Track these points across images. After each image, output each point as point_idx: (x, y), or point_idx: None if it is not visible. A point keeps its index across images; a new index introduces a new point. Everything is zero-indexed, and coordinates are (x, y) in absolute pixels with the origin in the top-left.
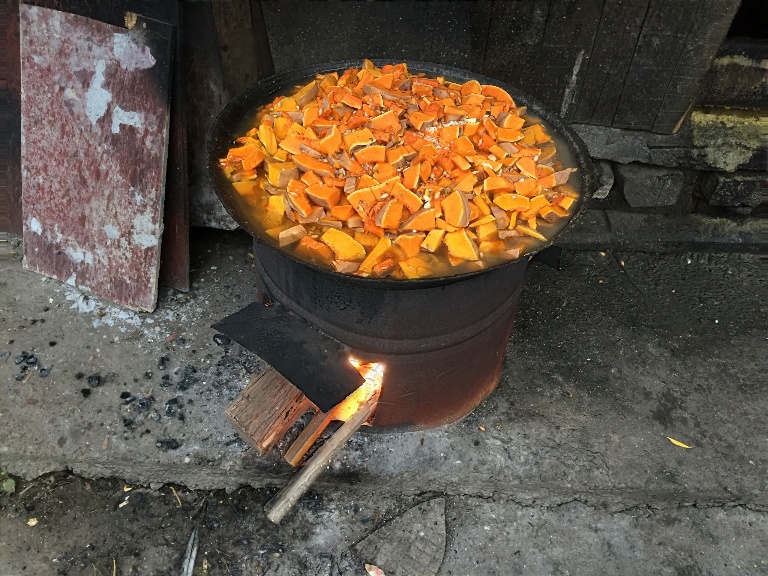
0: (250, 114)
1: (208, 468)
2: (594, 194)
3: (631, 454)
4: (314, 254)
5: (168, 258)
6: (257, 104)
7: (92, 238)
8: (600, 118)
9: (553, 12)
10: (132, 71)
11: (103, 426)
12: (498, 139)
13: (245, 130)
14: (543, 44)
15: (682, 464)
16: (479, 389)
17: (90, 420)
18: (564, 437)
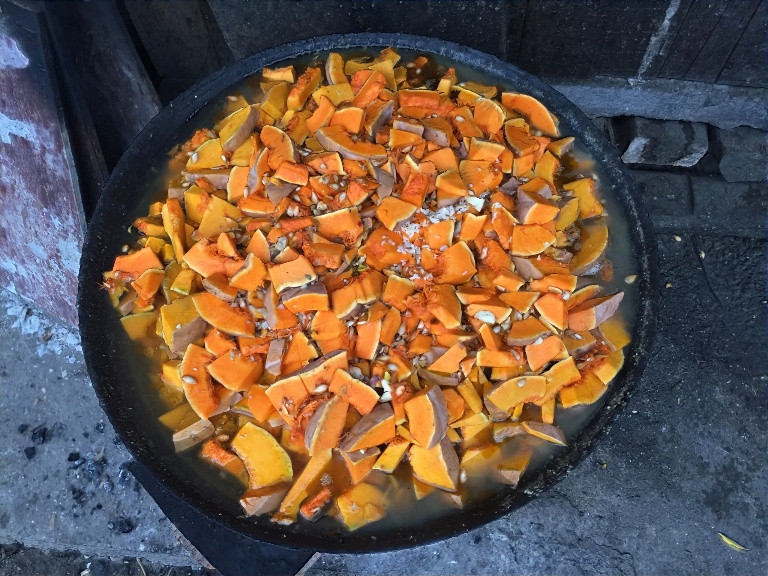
0: (159, 163)
1: (167, 553)
2: (677, 162)
3: (668, 555)
4: (222, 469)
5: None
6: (170, 141)
7: (18, 252)
8: (699, 73)
9: None
10: (3, 69)
11: (50, 498)
12: (512, 253)
13: (151, 194)
14: None
15: (731, 572)
16: None
17: (35, 490)
18: (588, 528)
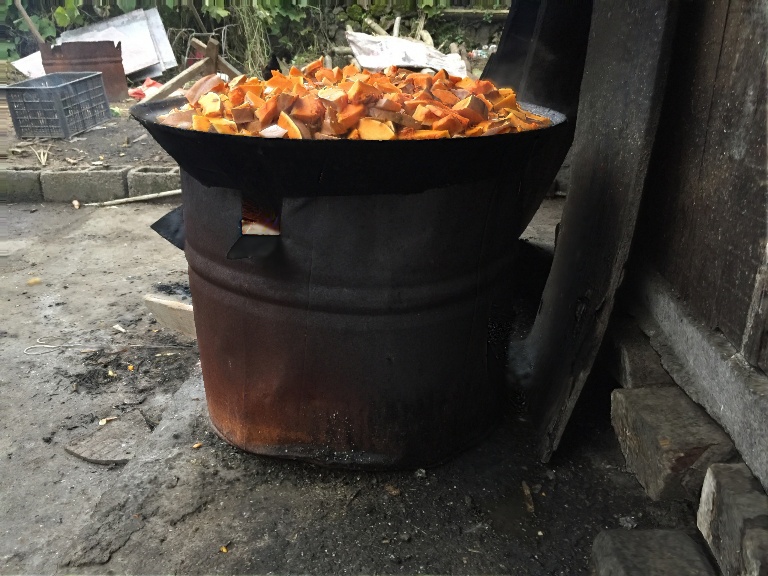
0: None
1: None
2: None
3: None
4: None
5: None
6: None
7: None
8: None
9: (763, 92)
10: None
11: None
12: None
13: None
14: (745, 160)
15: None
16: None
17: None
18: (155, 527)
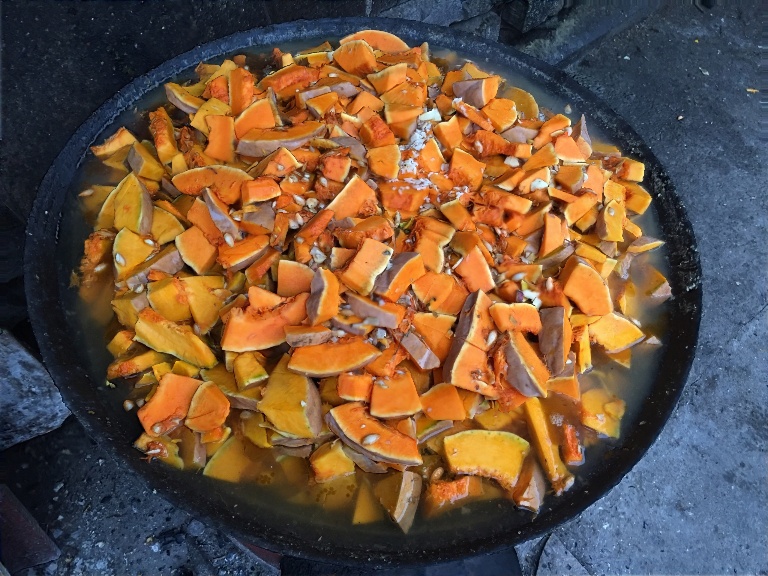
0: (68, 302)
1: None
2: None
3: None
4: (463, 503)
5: (2, 546)
6: (59, 274)
7: None
8: None
9: None
10: None
11: None
12: (502, 129)
13: (90, 339)
14: None
15: (702, 328)
16: None
17: None
18: None
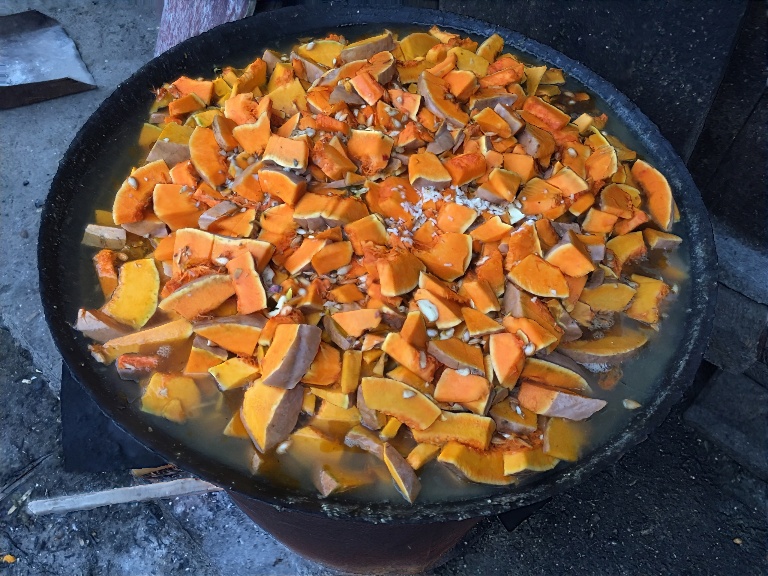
0: (286, 41)
1: None
2: None
3: None
4: None
5: None
6: (310, 32)
7: None
8: None
9: None
10: None
11: None
12: (508, 274)
13: None
14: None
15: None
16: (376, 563)
17: None
18: None
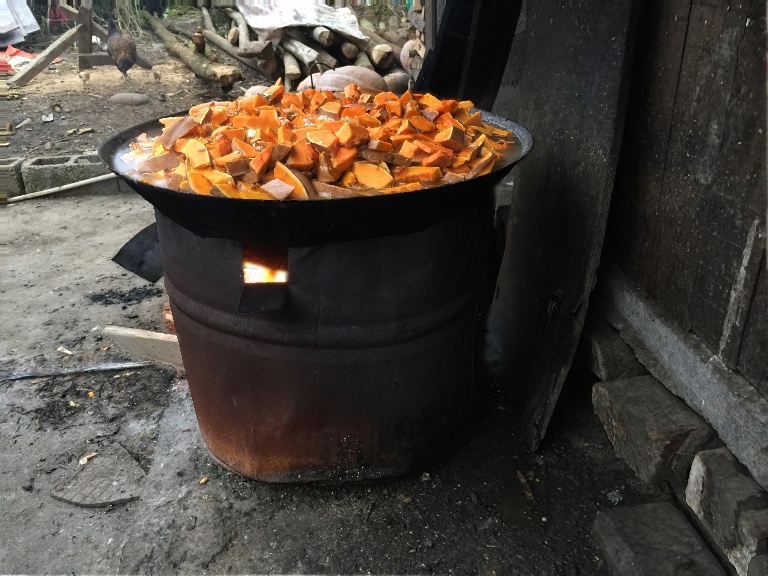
0: None
1: None
2: (732, 553)
3: None
4: None
5: None
6: None
7: None
8: None
9: (729, 130)
10: None
11: None
12: None
13: None
14: (713, 187)
15: None
16: (225, 435)
17: None
18: (188, 573)
